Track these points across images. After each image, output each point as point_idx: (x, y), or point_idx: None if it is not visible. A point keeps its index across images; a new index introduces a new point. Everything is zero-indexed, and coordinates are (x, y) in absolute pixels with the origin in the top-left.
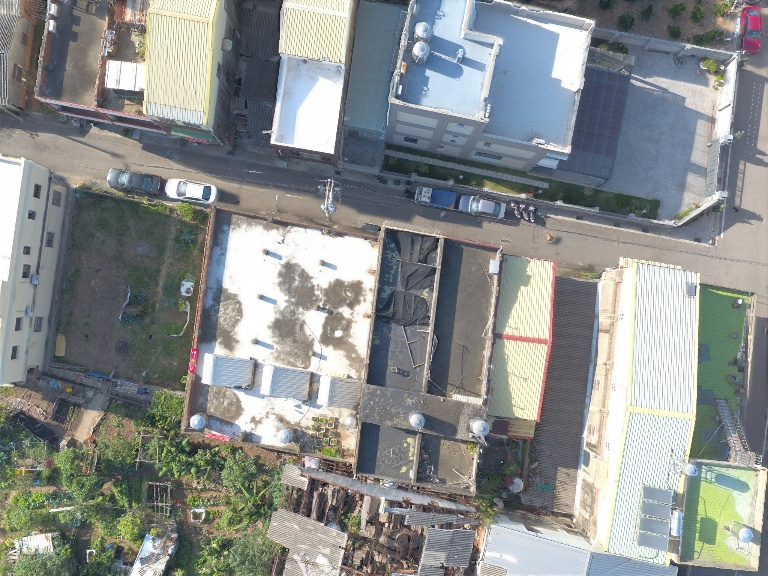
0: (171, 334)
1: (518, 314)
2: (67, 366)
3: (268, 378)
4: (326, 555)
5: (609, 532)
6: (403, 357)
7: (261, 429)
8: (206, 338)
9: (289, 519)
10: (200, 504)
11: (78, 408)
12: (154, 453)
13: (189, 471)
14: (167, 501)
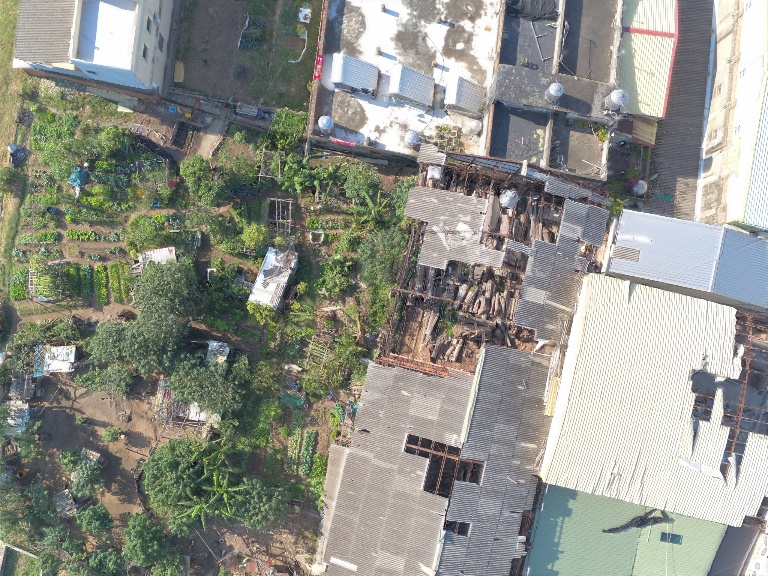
0: (289, 60)
1: (644, 10)
2: (186, 91)
3: (396, 76)
4: (467, 222)
5: (745, 202)
6: (532, 51)
7: (385, 138)
8: (330, 49)
9: (427, 194)
10: (319, 226)
11: (197, 133)
12: (276, 169)
13: (312, 184)
14: (288, 218)
